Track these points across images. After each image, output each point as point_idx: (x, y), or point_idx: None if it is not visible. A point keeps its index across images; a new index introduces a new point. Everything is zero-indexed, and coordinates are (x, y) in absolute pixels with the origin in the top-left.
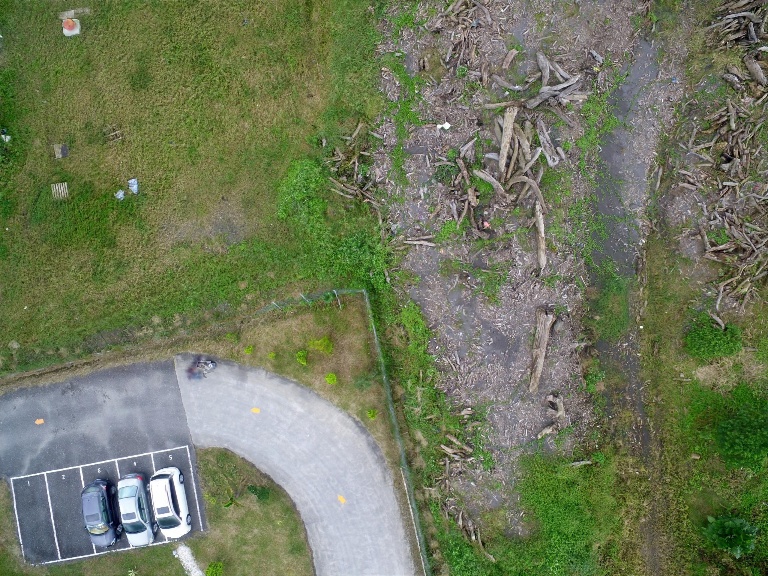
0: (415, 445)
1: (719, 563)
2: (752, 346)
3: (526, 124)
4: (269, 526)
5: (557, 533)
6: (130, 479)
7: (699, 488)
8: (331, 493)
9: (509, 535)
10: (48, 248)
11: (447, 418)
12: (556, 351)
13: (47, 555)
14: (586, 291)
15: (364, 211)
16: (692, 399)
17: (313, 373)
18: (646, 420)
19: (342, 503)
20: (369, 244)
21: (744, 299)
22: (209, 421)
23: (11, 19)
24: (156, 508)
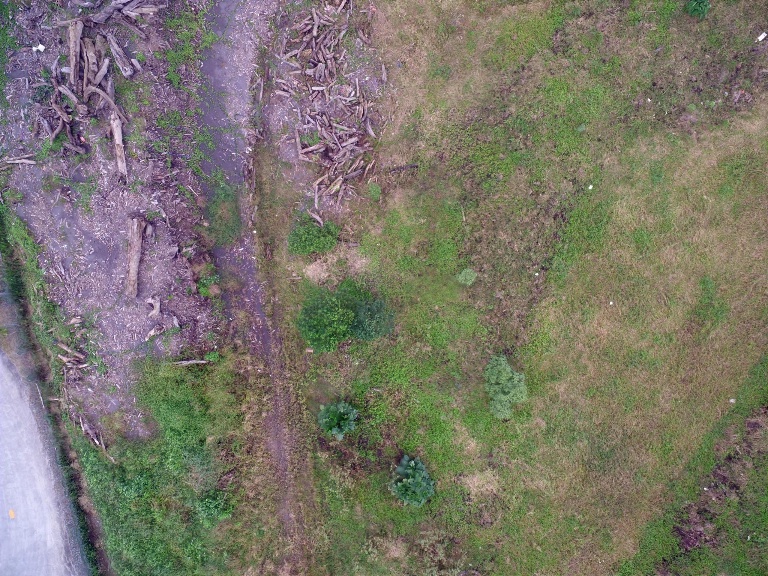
0: (48, 361)
1: (337, 449)
2: (355, 241)
3: (97, 38)
4: None
5: (170, 430)
6: None
7: (313, 379)
8: None
9: (130, 437)
10: None
11: (60, 328)
12: (154, 255)
13: None
14: (197, 200)
15: None
16: (303, 296)
17: None
18: (265, 320)
19: None
20: None
21: (338, 196)
22: None
23: None
24: None
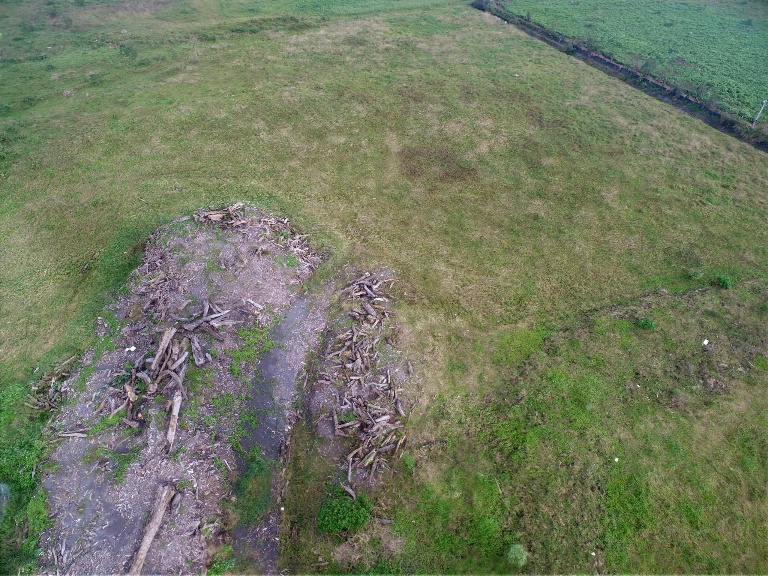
0: None
1: None
2: (388, 518)
3: (183, 339)
4: None
5: None
6: None
7: None
8: None
9: None
10: None
11: None
12: (172, 530)
13: None
14: (229, 474)
15: (46, 419)
16: None
17: None
18: None
19: None
20: (30, 442)
21: (371, 468)
22: None
23: None
24: None
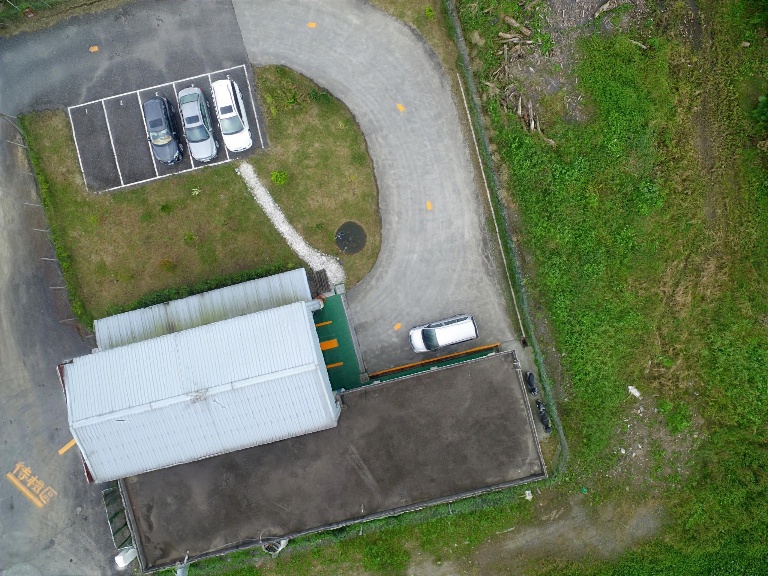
0: (471, 50)
1: None
2: None
3: None
4: (329, 139)
5: (614, 111)
6: (190, 88)
7: (749, 73)
8: (389, 102)
9: (567, 121)
10: None
11: (505, 3)
12: None
13: (109, 181)
14: None
15: None
16: None
17: None
18: (697, 13)
19: (401, 111)
20: None
21: None
22: (265, 38)
23: None
24: (219, 107)
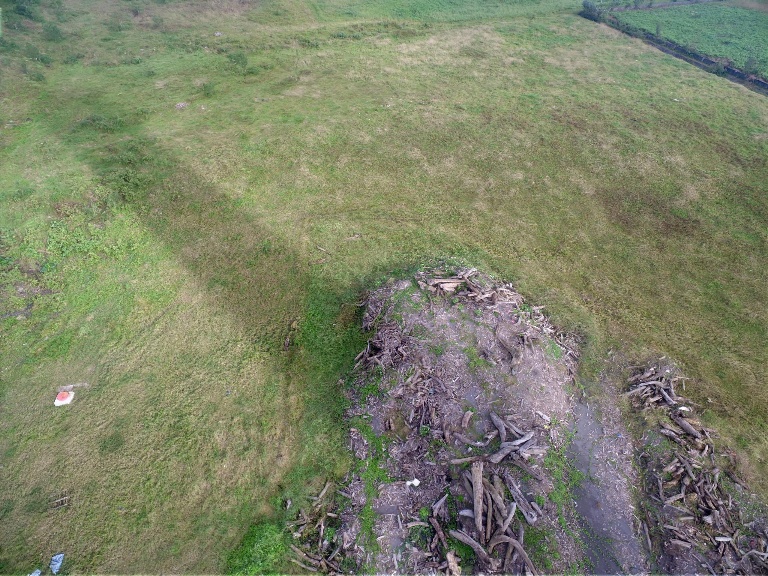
0: None
1: None
2: None
3: (494, 478)
4: None
5: None
6: None
7: None
8: None
9: None
10: None
11: None
12: None
13: None
14: None
15: None
16: None
17: None
18: None
19: None
20: None
21: None
22: None
23: (10, 392)
24: None
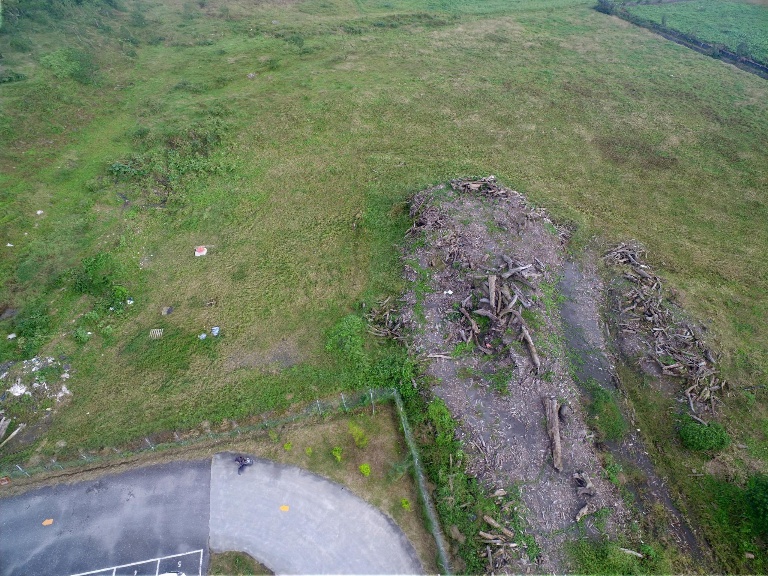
0: (452, 546)
1: None
2: (741, 444)
3: (504, 285)
4: None
5: None
6: None
7: None
8: None
9: None
10: (130, 369)
11: (482, 501)
12: (569, 435)
13: None
14: (580, 399)
15: (393, 345)
16: (714, 493)
17: (346, 470)
18: (681, 517)
19: None
20: (399, 361)
21: (711, 403)
22: (233, 520)
23: (163, 248)
24: None
